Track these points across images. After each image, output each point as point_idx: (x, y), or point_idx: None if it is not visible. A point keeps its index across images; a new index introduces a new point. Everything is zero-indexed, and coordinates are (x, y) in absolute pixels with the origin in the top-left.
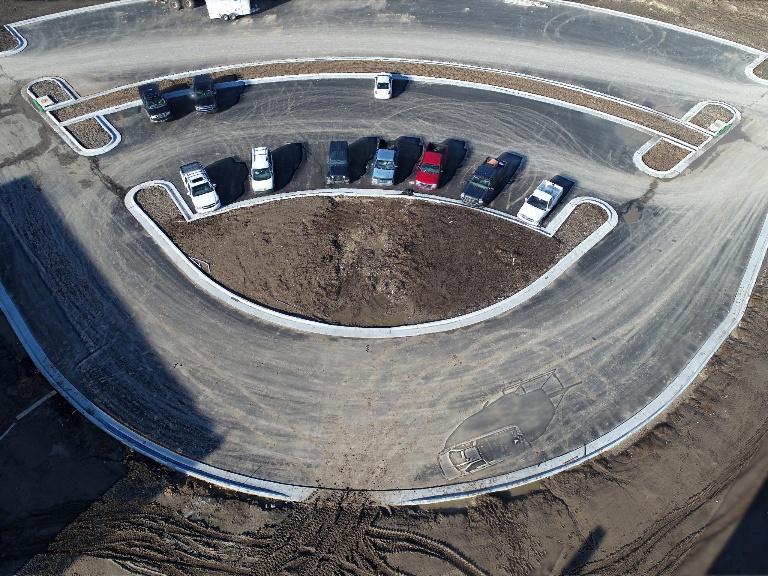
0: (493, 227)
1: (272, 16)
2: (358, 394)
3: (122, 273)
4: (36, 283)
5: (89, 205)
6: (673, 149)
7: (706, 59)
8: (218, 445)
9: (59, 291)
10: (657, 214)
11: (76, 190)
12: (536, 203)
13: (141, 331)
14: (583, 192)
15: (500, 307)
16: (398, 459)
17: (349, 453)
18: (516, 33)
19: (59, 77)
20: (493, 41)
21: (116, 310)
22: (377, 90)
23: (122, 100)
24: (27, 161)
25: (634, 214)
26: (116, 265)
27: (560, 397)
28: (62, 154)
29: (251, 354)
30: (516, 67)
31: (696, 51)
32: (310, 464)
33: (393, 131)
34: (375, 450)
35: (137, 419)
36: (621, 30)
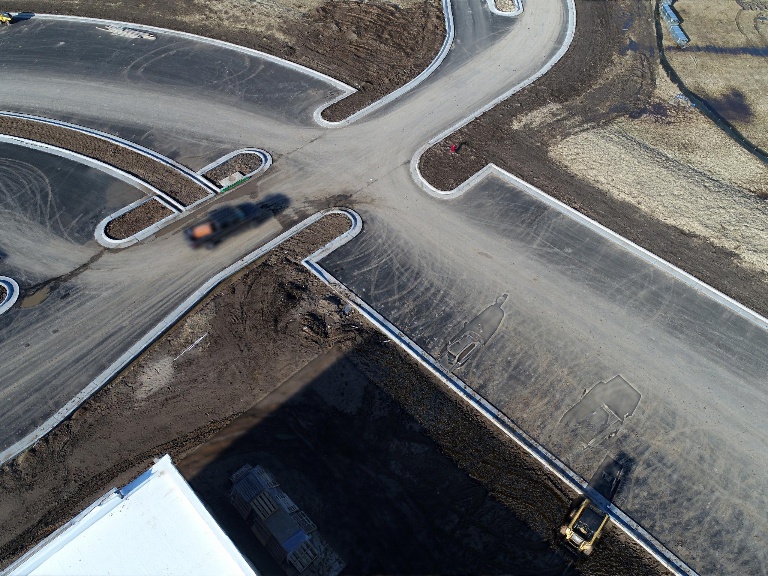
0: None
1: None
2: None
3: None
4: None
5: None
6: (156, 210)
7: (284, 97)
8: None
9: None
10: (65, 296)
11: None
12: None
13: None
14: (0, 270)
15: None
16: None
17: None
18: (93, 71)
19: None
20: (59, 81)
21: None
22: None
23: None
24: None
25: (39, 297)
26: None
27: None
28: None
29: None
30: (59, 112)
31: (280, 88)
32: None
33: None
34: None
35: None
36: (216, 64)
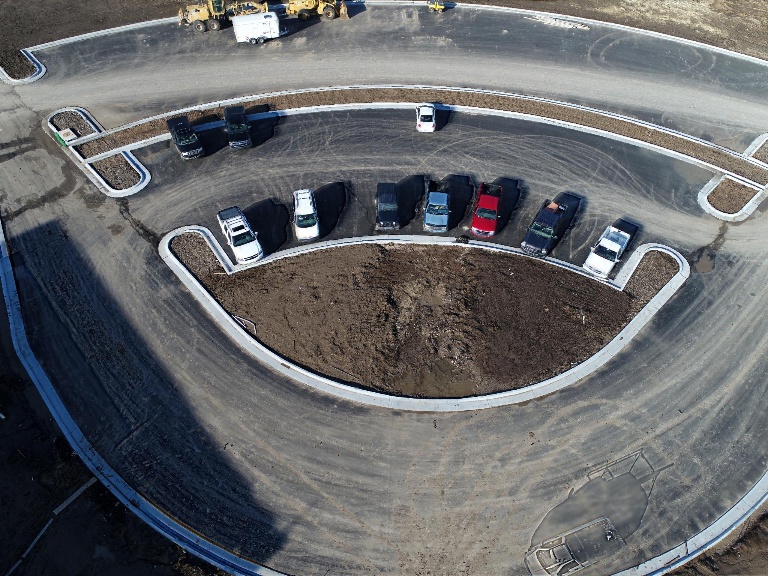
0: (558, 280)
1: (302, 39)
2: (429, 480)
3: (161, 335)
4: (68, 347)
5: (120, 254)
6: (739, 188)
7: (761, 86)
8: (279, 544)
9: (93, 356)
10: (731, 263)
11: (106, 237)
12: (603, 253)
13: (185, 404)
14: (649, 238)
15: (574, 374)
16: (481, 560)
17: (426, 553)
18: (559, 58)
19: (81, 107)
20: (536, 67)
21: (157, 379)
22: (420, 123)
23: (149, 133)
24: (51, 203)
25: (706, 263)
26: (154, 325)
27: (651, 482)
28: (88, 195)
29: (308, 431)
30: (563, 96)
31: (750, 77)
32: (383, 567)
33: (440, 168)
34: (454, 549)
35: (187, 512)
36: (669, 54)
